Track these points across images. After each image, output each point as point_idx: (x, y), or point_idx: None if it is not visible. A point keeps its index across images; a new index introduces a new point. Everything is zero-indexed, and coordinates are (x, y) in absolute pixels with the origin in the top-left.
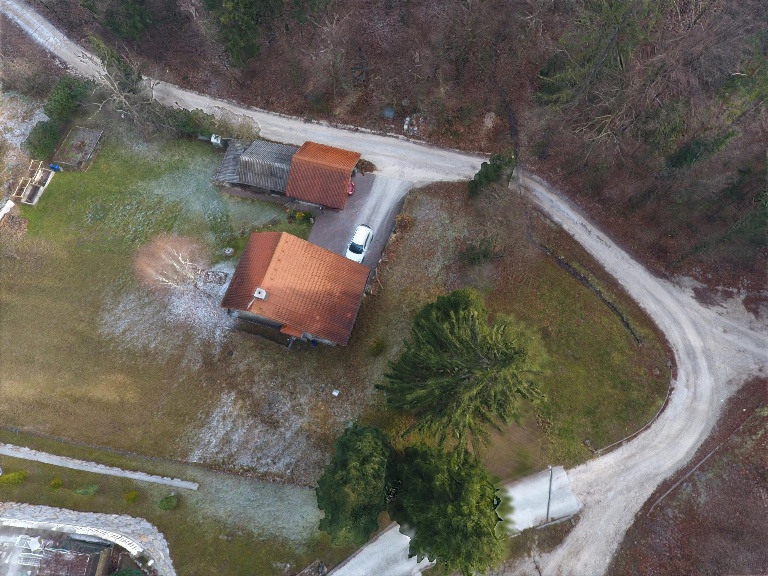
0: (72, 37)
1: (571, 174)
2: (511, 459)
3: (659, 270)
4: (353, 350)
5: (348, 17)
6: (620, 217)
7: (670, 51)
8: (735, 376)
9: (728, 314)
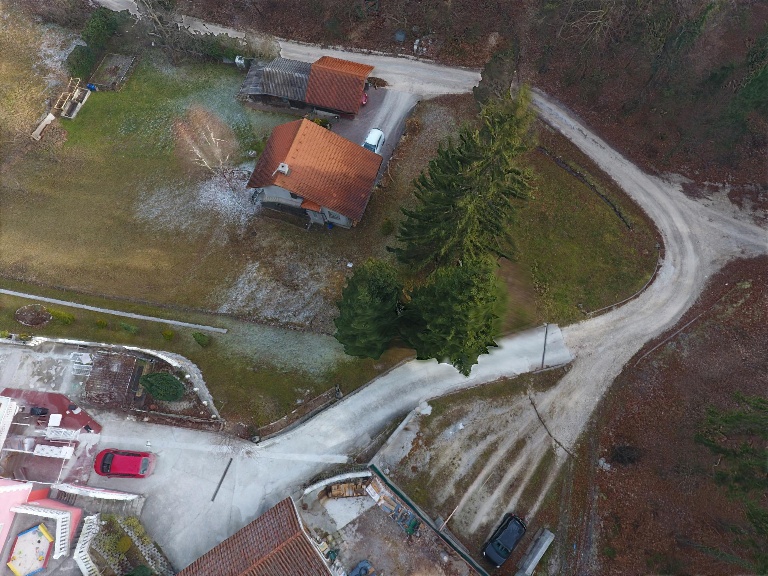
0: None
1: (569, 86)
2: (510, 316)
3: (650, 168)
4: (366, 232)
5: None
6: (614, 122)
7: None
8: (719, 257)
9: (714, 205)
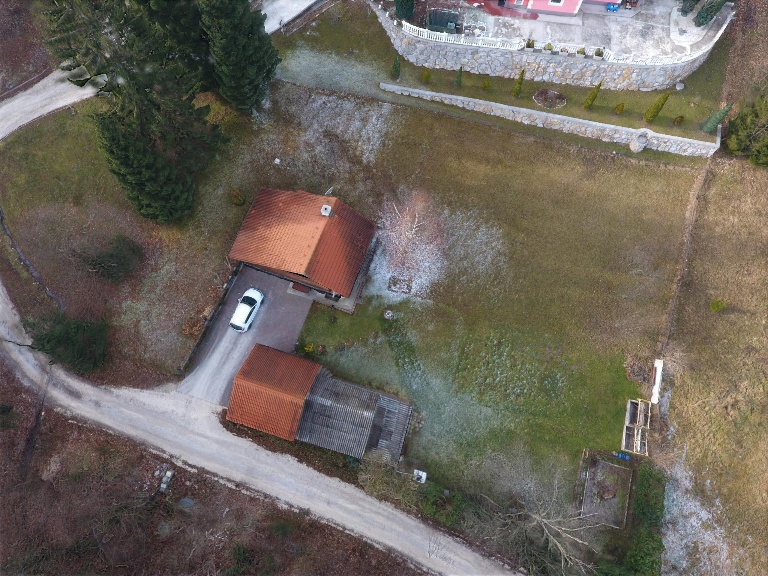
0: None
1: None
2: None
3: None
4: None
5: None
6: None
7: None
8: None
9: None
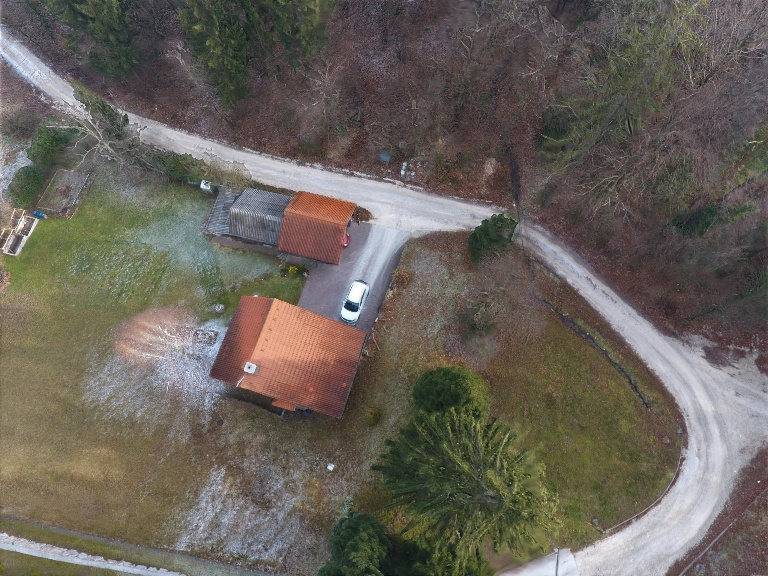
0: (58, 71)
1: (575, 224)
2: None
3: (668, 328)
4: (349, 418)
5: (341, 66)
6: (626, 270)
7: (680, 109)
8: (748, 444)
9: (740, 375)
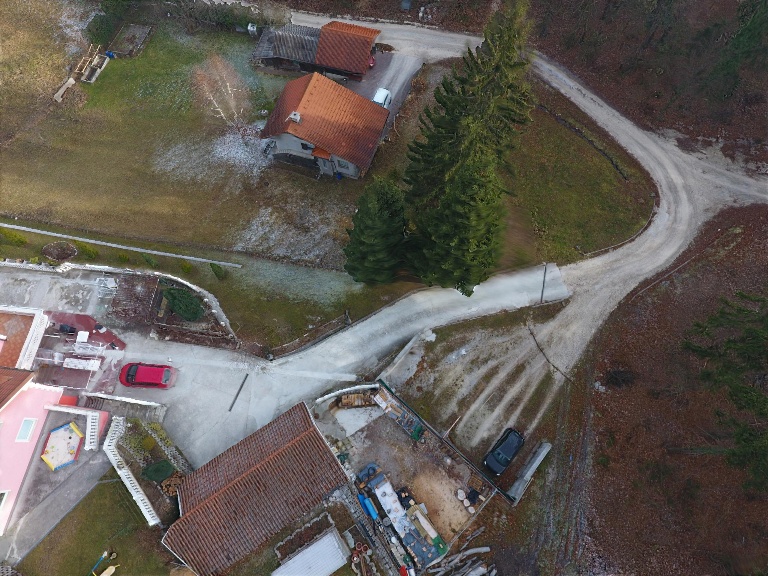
0: None
1: (568, 49)
2: (510, 255)
3: (646, 124)
4: None
5: None
6: (612, 82)
7: None
8: (712, 206)
9: (707, 159)
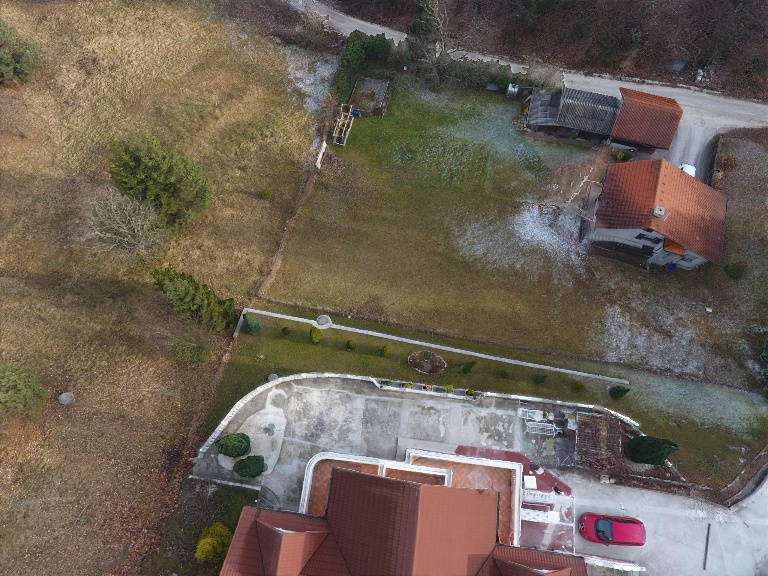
0: None
1: None
2: None
3: None
4: (709, 274)
5: None
6: None
7: None
8: None
9: None
